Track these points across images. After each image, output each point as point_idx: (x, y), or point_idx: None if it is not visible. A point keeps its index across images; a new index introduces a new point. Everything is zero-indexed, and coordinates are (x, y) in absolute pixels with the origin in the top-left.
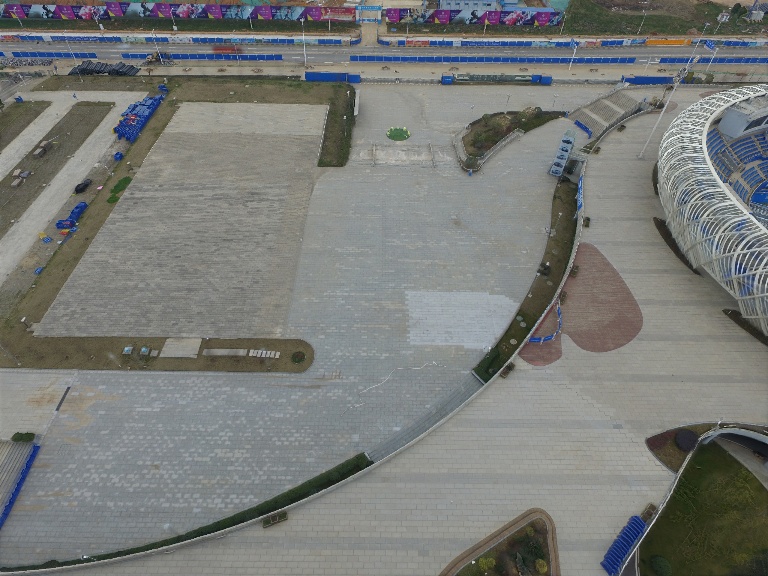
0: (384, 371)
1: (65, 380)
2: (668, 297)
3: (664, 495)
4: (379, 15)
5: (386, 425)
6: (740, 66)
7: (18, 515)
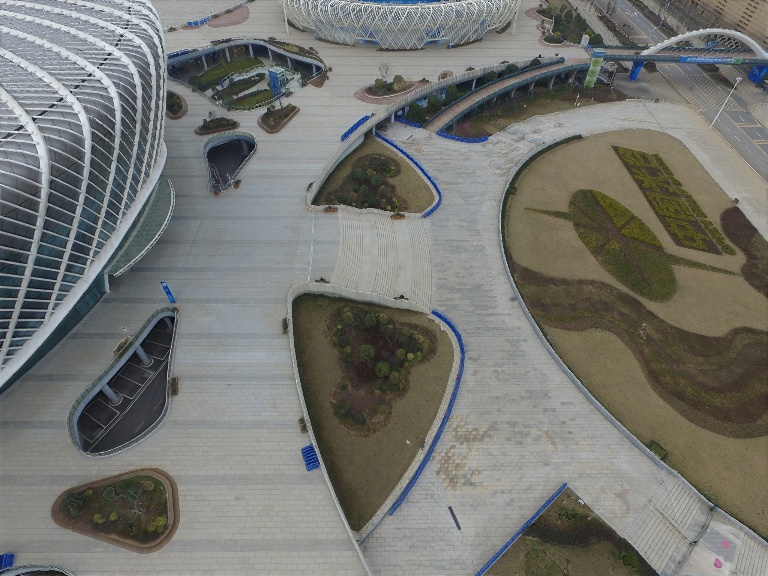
0: None
1: None
2: (264, 17)
3: (205, 49)
4: None
5: None
6: None
7: None
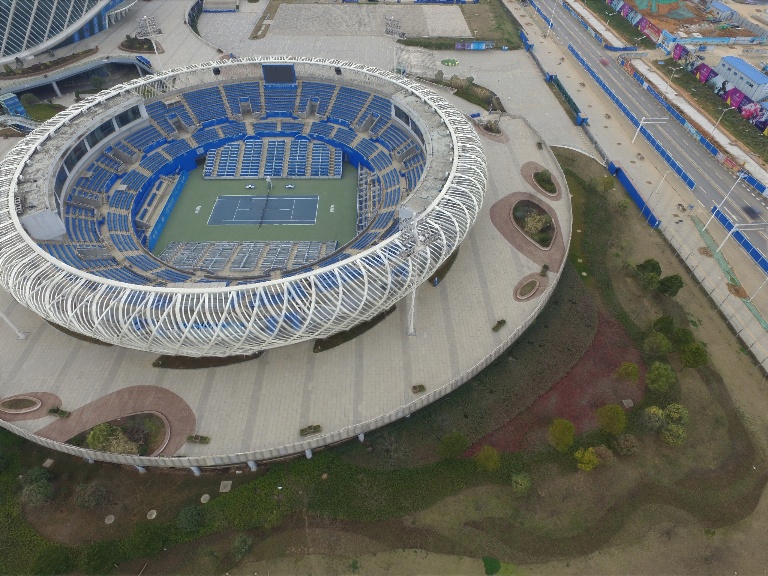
0: (243, 50)
1: (260, 11)
2: None
3: None
4: (670, 46)
5: None
6: None
7: (215, 13)
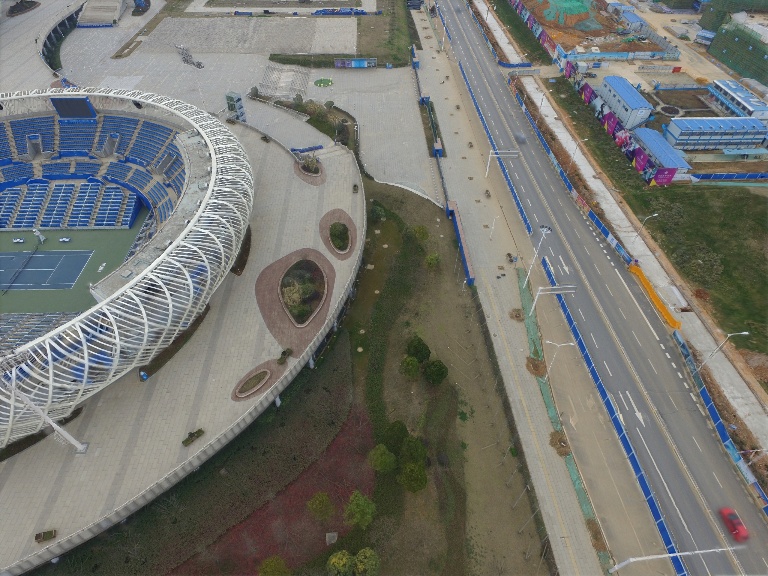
0: None
1: None
2: None
3: None
4: (562, 63)
5: (70, 72)
6: (586, 384)
7: None
